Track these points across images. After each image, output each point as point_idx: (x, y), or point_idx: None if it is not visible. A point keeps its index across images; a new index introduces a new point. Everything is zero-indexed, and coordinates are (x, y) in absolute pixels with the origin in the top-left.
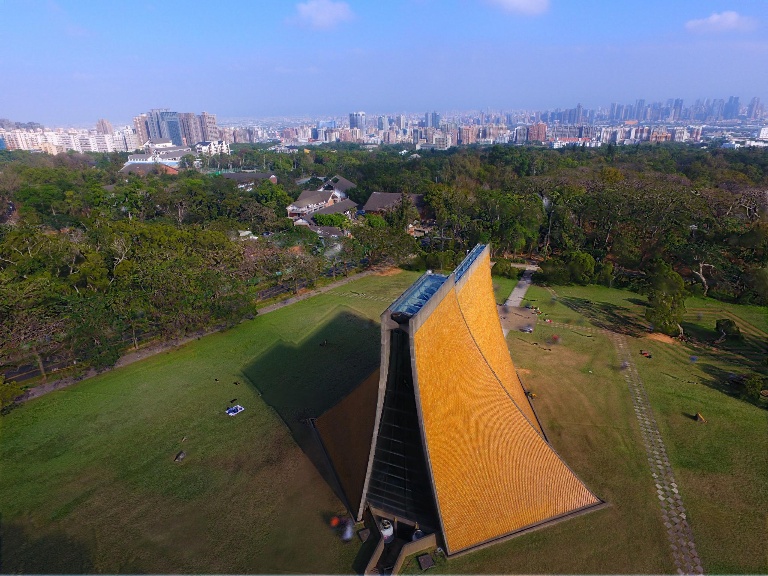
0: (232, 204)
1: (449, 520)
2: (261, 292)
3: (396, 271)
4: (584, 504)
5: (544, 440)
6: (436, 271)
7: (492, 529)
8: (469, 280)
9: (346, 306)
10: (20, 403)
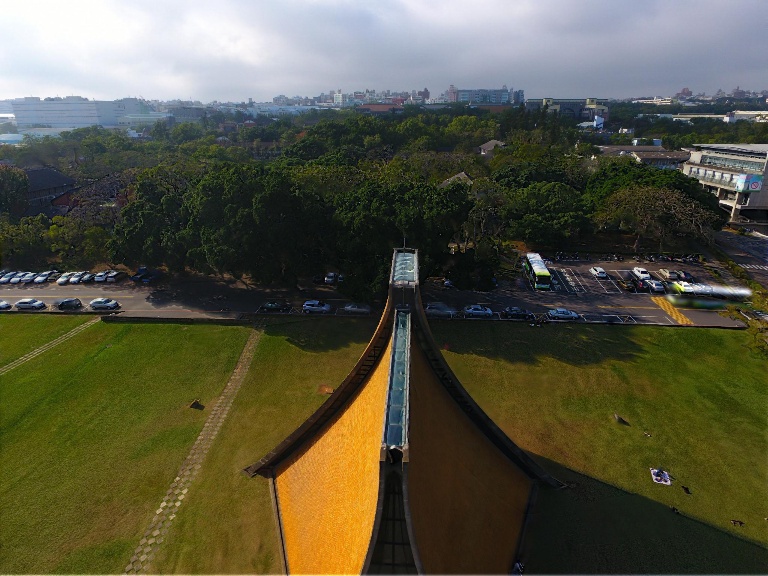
0: None
1: None
2: None
3: None
4: None
5: None
6: None
7: None
8: None
9: None
10: None
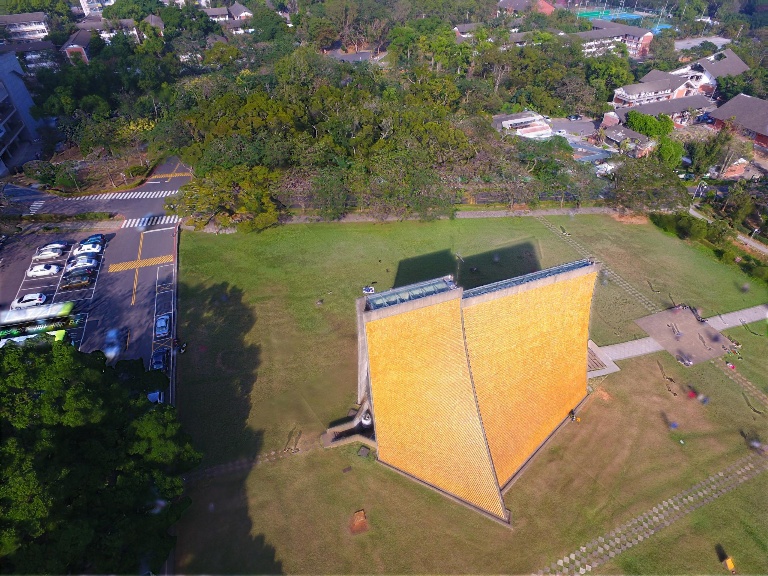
0: (553, 76)
1: (382, 442)
2: (477, 196)
3: (640, 220)
4: (491, 511)
5: (487, 449)
6: (687, 239)
7: (411, 469)
8: (520, 294)
9: (537, 240)
10: (284, 223)
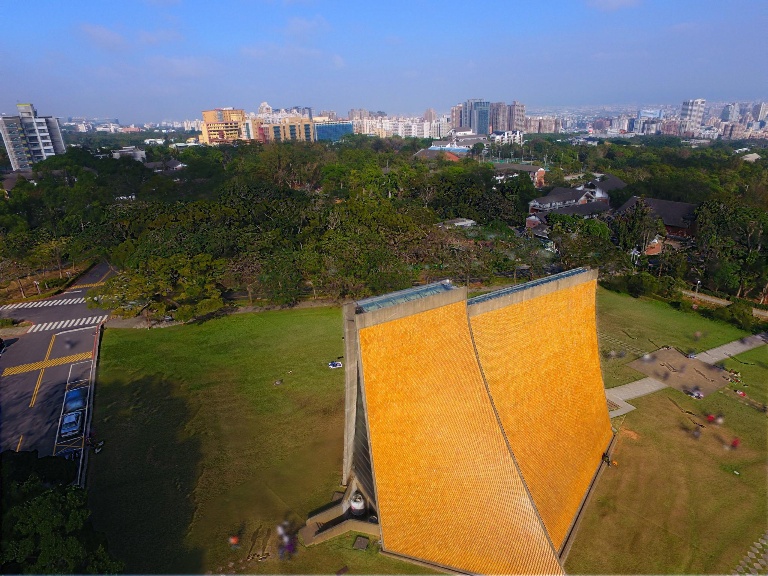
0: (474, 193)
1: (387, 518)
2: (433, 277)
3: None
4: None
5: (530, 499)
6: (641, 297)
7: (432, 553)
8: (525, 302)
9: None
10: (229, 314)
